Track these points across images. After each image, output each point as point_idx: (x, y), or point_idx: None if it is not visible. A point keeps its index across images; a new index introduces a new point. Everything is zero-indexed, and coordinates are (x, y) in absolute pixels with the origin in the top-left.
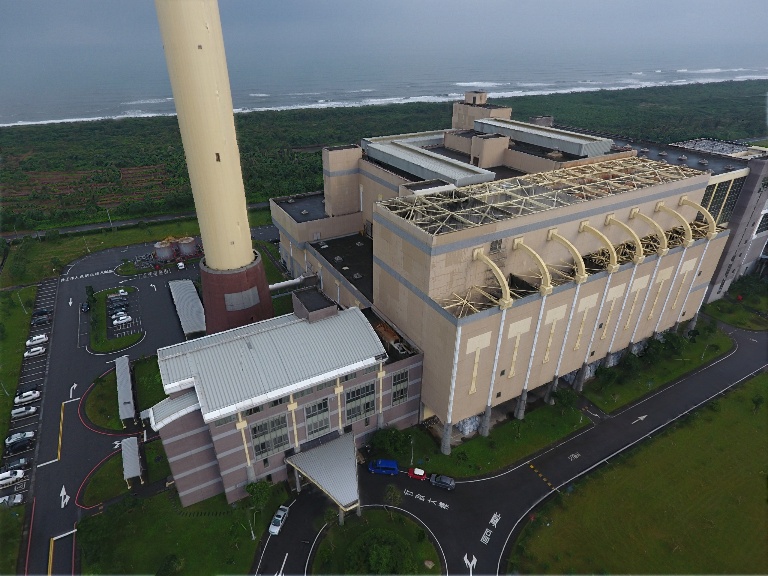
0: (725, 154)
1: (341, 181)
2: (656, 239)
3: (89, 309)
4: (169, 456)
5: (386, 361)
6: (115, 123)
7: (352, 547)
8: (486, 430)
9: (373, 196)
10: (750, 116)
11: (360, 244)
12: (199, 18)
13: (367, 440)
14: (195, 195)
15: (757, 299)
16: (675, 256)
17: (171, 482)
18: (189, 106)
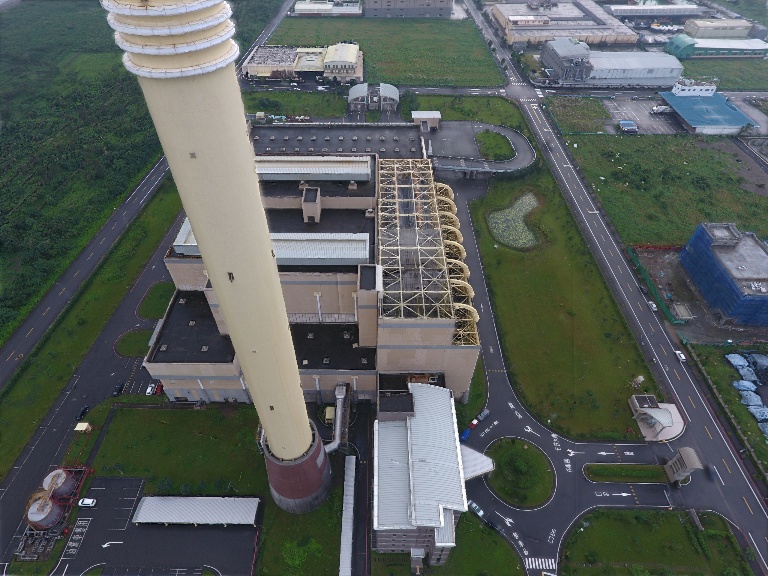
0: (292, 64)
1: None
2: None
3: None
4: None
5: None
6: None
7: None
8: None
9: None
10: None
11: None
12: None
13: None
14: (285, 425)
15: None
16: None
17: (418, 570)
18: (286, 374)
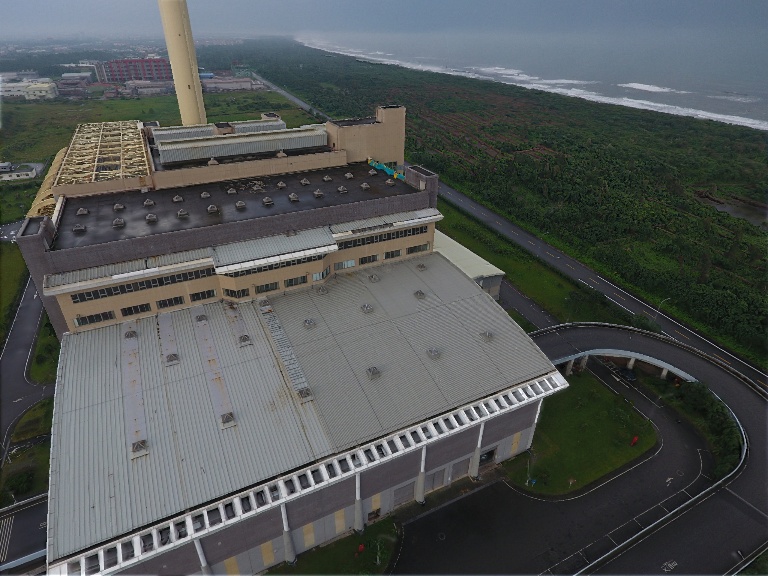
0: None
1: None
2: None
3: None
4: None
5: None
6: (671, 120)
7: None
8: None
9: None
10: None
11: None
12: None
13: None
14: None
15: None
16: None
17: None
18: None
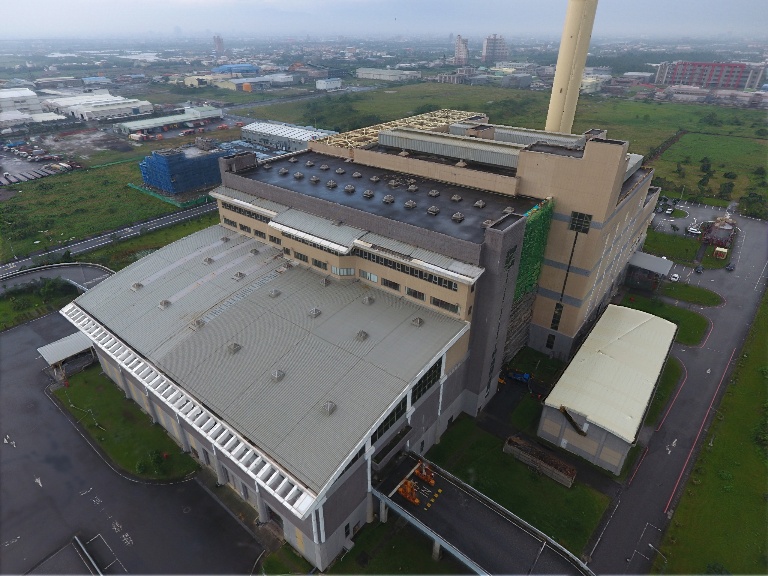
0: None
1: None
2: None
3: (661, 205)
4: None
5: None
6: None
7: None
8: None
9: None
10: None
11: None
12: None
13: None
14: None
15: None
16: None
17: None
18: None
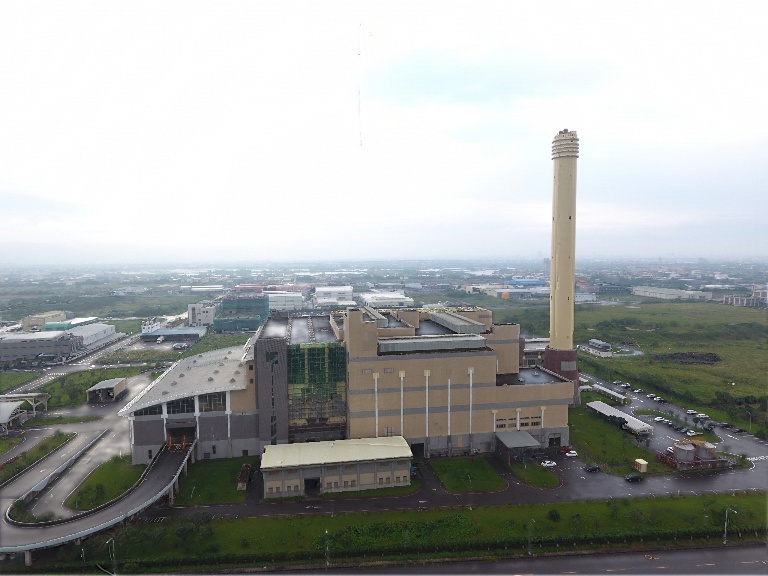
0: None
1: None
2: None
3: None
4: None
5: None
6: None
7: None
8: None
9: None
10: None
11: None
12: None
13: None
14: None
15: None
16: None
17: None
18: None
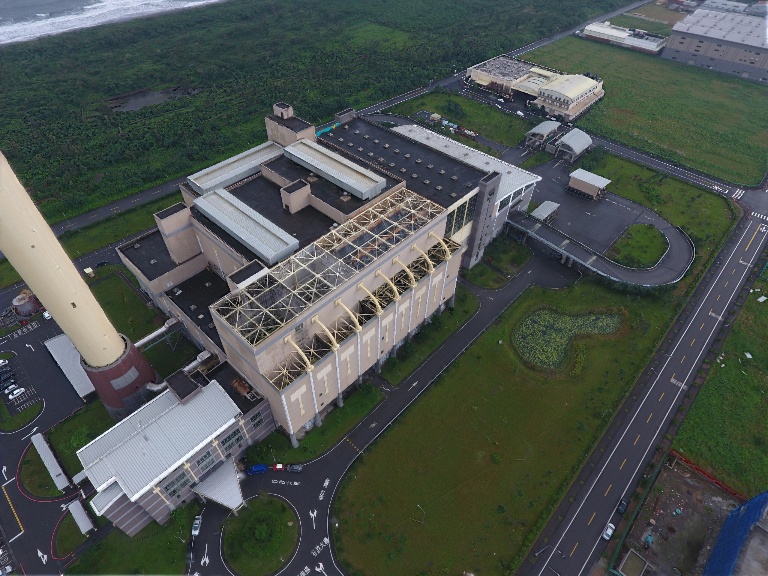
0: (511, 81)
1: (178, 237)
2: (418, 259)
3: None
4: (113, 521)
5: (243, 410)
6: None
7: (245, 529)
8: (319, 424)
9: (209, 247)
10: (548, 5)
11: (208, 284)
12: (25, 229)
13: (243, 453)
14: (62, 328)
15: (500, 260)
16: (425, 281)
17: None
18: (37, 283)
